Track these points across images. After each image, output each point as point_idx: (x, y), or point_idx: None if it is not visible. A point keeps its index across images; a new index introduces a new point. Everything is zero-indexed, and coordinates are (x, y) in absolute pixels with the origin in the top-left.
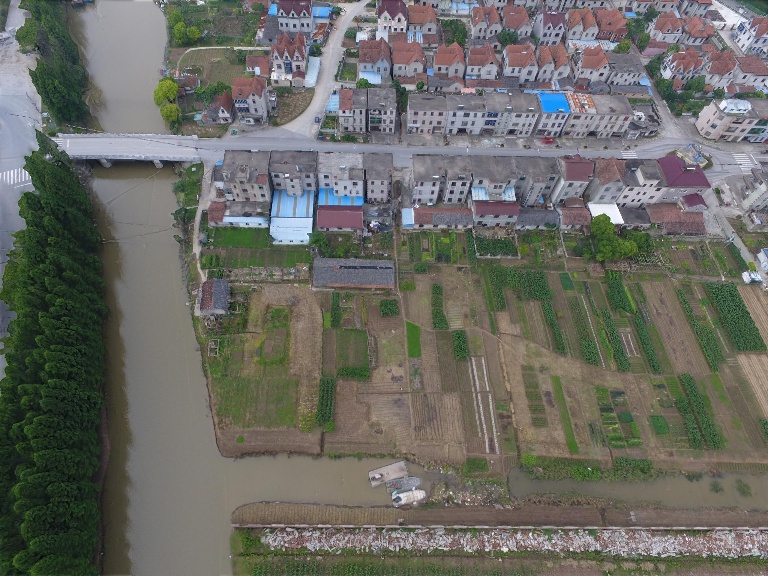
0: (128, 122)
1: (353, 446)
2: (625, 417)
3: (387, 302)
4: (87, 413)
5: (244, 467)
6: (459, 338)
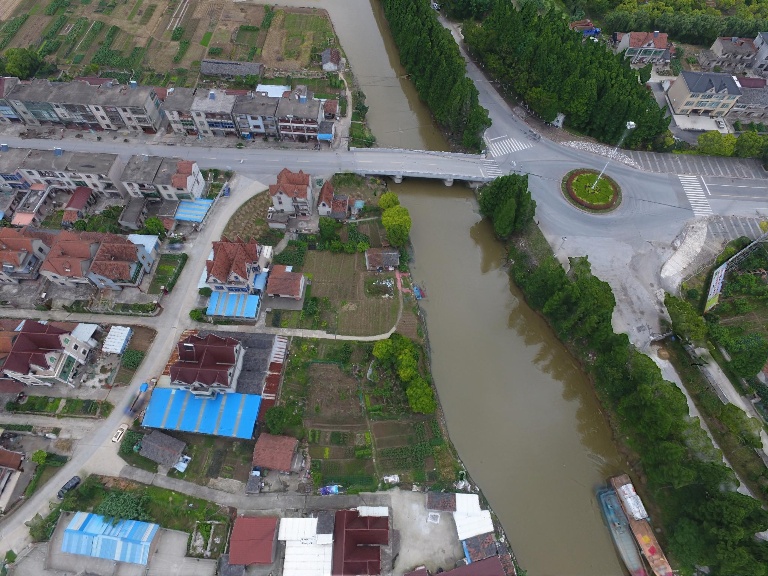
0: (464, 277)
1: (257, 4)
2: (103, 3)
3: (215, 51)
4: (387, 3)
5: (314, 5)
6: (177, 34)
